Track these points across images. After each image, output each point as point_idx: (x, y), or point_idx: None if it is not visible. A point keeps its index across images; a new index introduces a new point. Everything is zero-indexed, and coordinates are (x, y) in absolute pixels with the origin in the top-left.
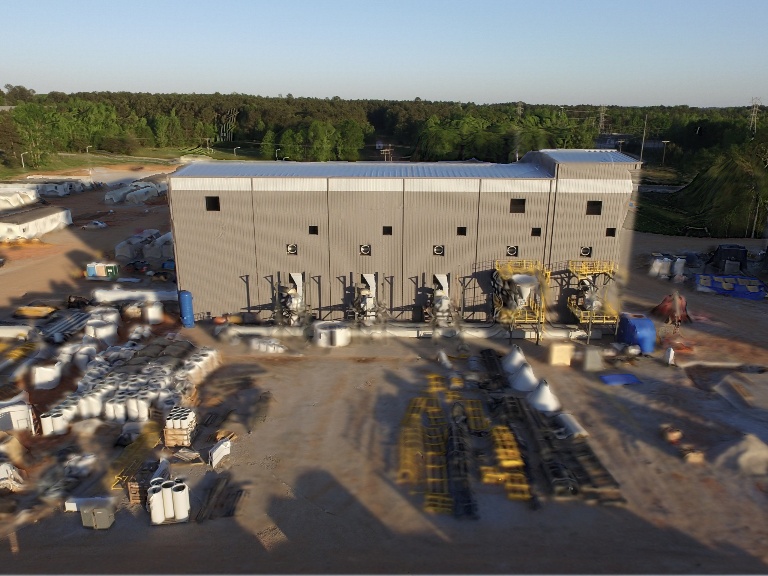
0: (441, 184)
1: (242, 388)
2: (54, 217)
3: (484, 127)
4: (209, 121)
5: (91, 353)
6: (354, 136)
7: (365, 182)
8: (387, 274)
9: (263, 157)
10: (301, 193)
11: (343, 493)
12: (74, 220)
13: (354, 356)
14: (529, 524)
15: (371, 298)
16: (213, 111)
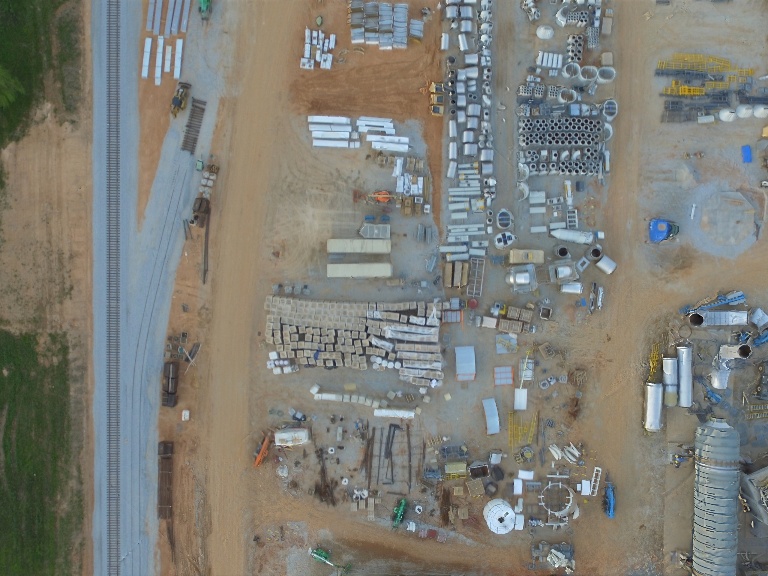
0: None
1: None
2: None
3: None
4: None
5: None
6: None
7: None
8: None
9: None
10: None
11: (668, 35)
12: None
13: None
14: (653, 91)
15: None
16: None
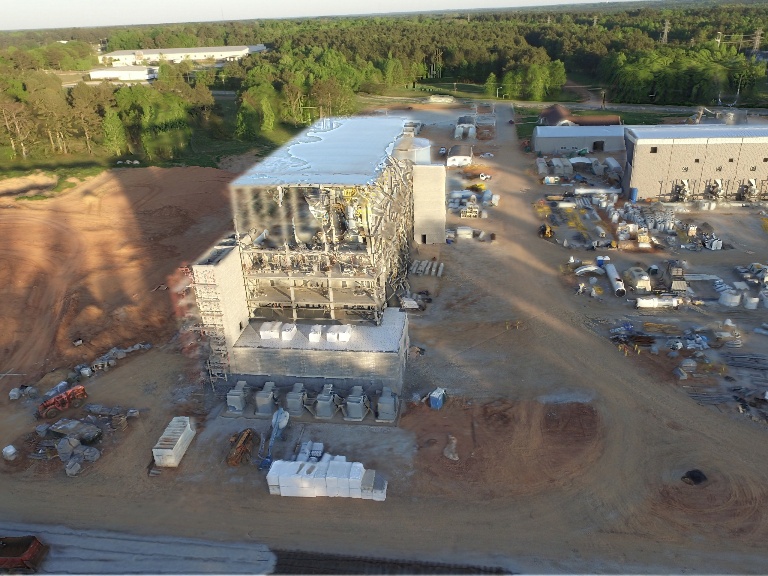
0: (760, 140)
1: (691, 222)
2: None
3: (667, 64)
4: (420, 61)
5: None
6: (559, 75)
7: (725, 139)
8: (728, 179)
9: (487, 94)
10: (694, 145)
11: (762, 245)
12: None
13: (722, 213)
14: None
15: (723, 190)
16: (422, 52)
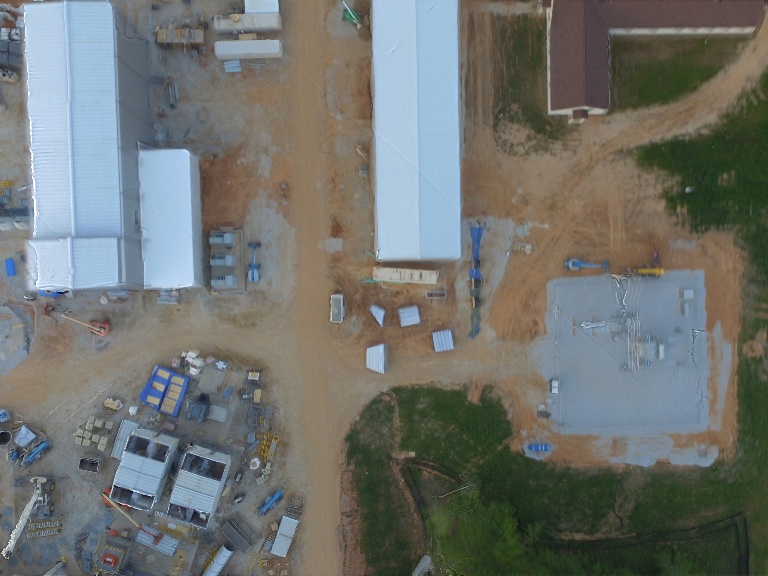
0: None
1: None
2: None
3: None
4: None
5: (8, 17)
6: None
7: None
8: None
9: None
10: None
11: None
12: None
13: None
14: None
15: None
16: None
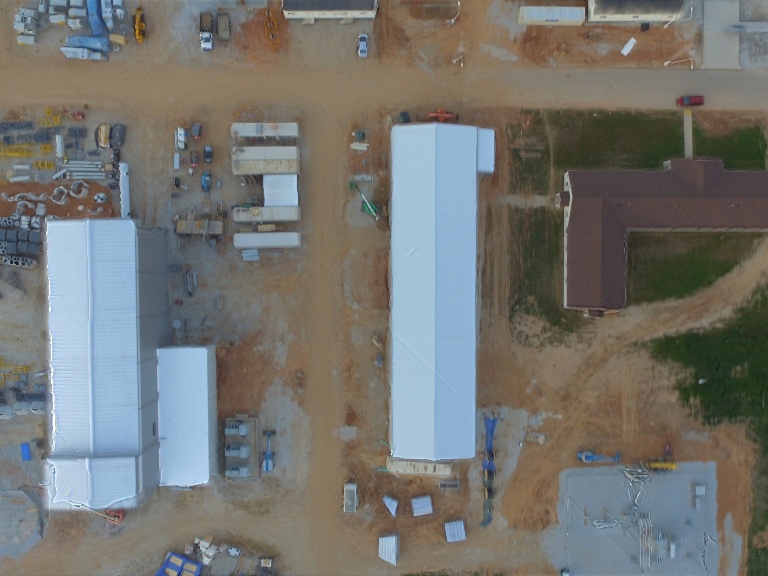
0: None
1: (10, 283)
2: (339, 12)
3: None
4: None
5: (28, 205)
6: None
7: None
8: None
9: None
10: None
11: None
12: (405, 2)
13: None
14: None
15: None
16: None
